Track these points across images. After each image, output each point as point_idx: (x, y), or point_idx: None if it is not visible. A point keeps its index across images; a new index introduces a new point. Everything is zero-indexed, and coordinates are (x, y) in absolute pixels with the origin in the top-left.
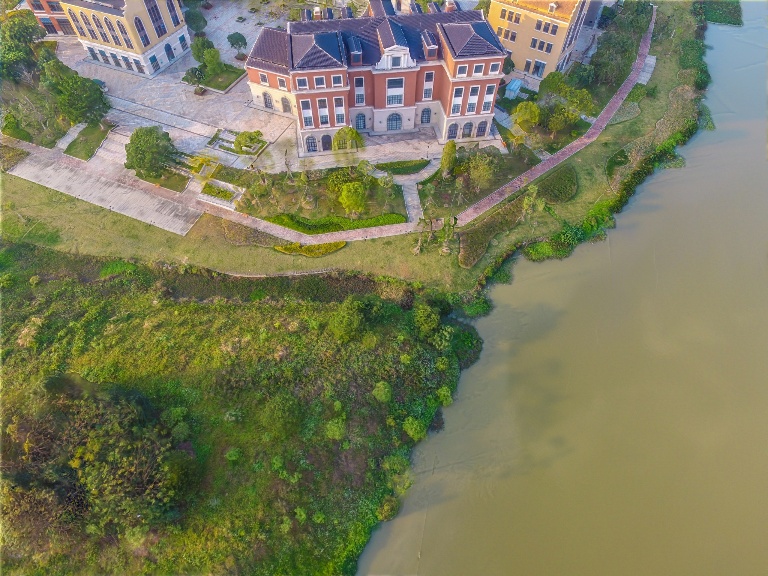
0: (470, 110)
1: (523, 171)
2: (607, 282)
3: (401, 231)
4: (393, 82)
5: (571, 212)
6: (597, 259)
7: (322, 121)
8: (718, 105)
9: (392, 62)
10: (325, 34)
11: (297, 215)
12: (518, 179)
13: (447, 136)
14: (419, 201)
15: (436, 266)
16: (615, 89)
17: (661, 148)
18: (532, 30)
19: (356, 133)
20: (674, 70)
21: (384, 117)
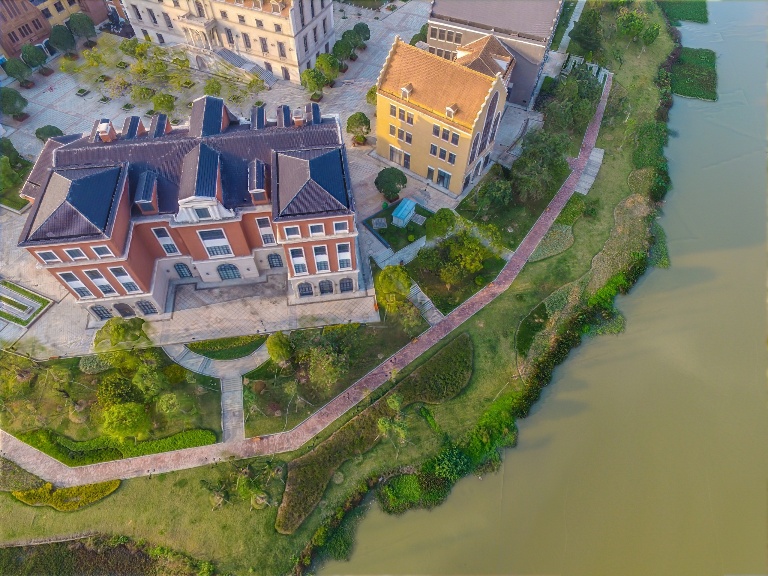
0: (322, 268)
1: (400, 346)
2: (490, 555)
3: (206, 459)
4: (209, 233)
5: (457, 417)
6: (482, 508)
7: (105, 290)
8: (677, 226)
9: (197, 214)
10: (96, 175)
11: (60, 432)
12: (391, 359)
13: (299, 294)
14: (242, 404)
15: (241, 531)
16: (545, 203)
17: (595, 301)
18: (429, 135)
19: (126, 332)
20: (625, 171)
21: (211, 268)
